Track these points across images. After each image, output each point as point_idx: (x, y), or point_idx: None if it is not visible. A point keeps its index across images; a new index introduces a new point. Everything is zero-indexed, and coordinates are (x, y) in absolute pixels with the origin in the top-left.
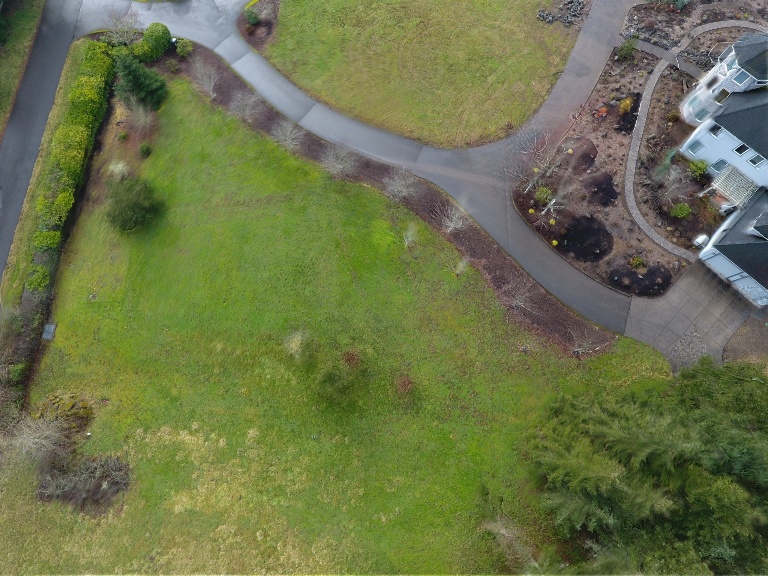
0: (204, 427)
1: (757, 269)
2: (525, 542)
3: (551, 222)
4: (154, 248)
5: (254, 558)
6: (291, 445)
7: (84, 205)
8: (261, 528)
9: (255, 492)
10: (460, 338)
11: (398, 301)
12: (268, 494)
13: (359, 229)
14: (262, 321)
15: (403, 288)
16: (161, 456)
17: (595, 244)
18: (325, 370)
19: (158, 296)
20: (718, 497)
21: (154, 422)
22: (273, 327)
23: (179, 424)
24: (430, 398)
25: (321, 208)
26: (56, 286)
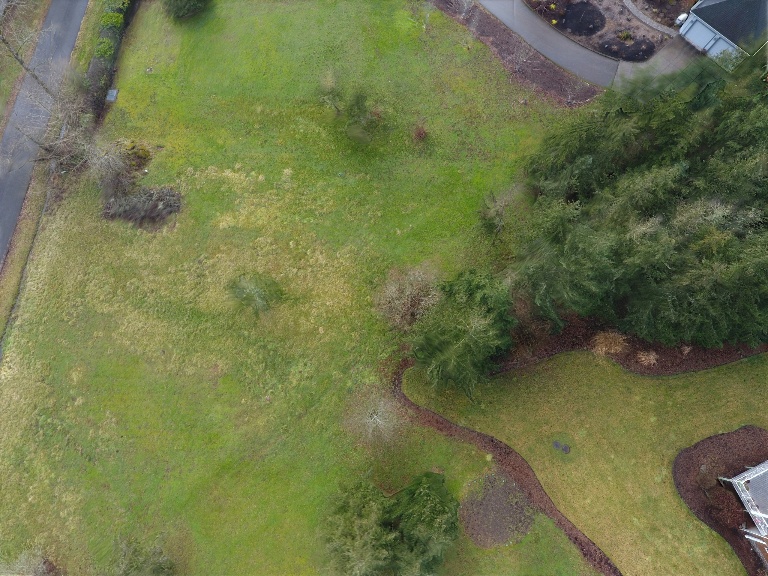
0: (245, 167)
1: (727, 26)
2: (519, 245)
3: (552, 6)
4: (203, 34)
5: (287, 261)
6: (320, 180)
7: (142, 1)
8: (294, 239)
9: (289, 213)
10: (469, 96)
11: (416, 70)
12: (300, 215)
13: (383, 17)
14: (297, 89)
15: (421, 60)
16: (208, 187)
17: (589, 21)
18: (354, 93)
19: (206, 70)
20: (675, 111)
21: (202, 163)
22: (306, 94)
23: (224, 165)
24: (441, 144)
25: (350, 2)
26: (118, 61)
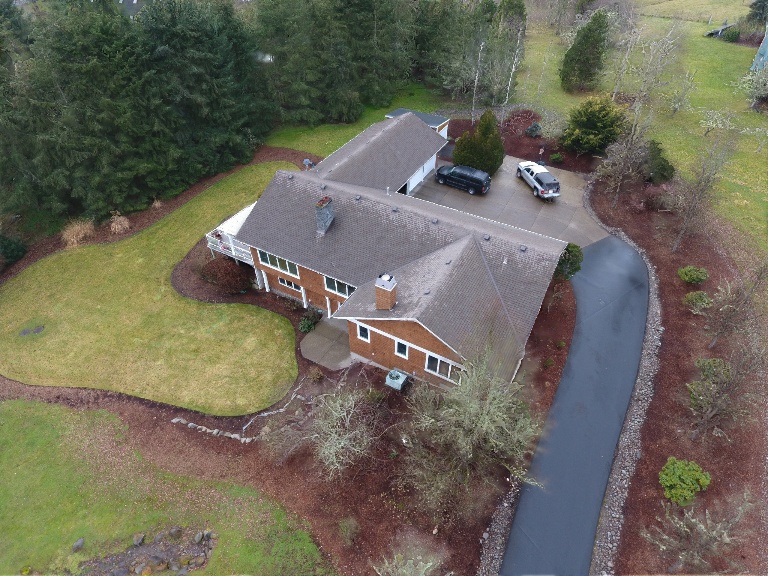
0: None
1: None
2: None
3: None
4: None
5: None
6: None
7: None
8: None
9: None
10: None
11: None
12: None
13: None
14: None
15: None
16: None
17: None
18: None
19: None
20: None
21: None
22: None
23: None
24: None
25: None
26: None
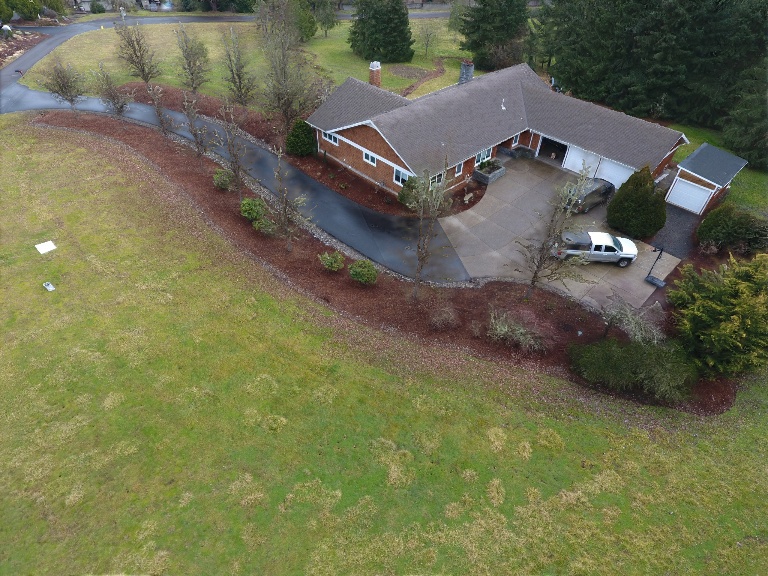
0: None
1: None
2: None
3: None
4: None
5: None
6: None
7: None
8: None
9: None
10: None
11: None
12: None
13: None
14: None
15: None
16: None
17: None
18: None
19: None
20: None
21: None
22: None
23: None
24: None
25: None
26: None
